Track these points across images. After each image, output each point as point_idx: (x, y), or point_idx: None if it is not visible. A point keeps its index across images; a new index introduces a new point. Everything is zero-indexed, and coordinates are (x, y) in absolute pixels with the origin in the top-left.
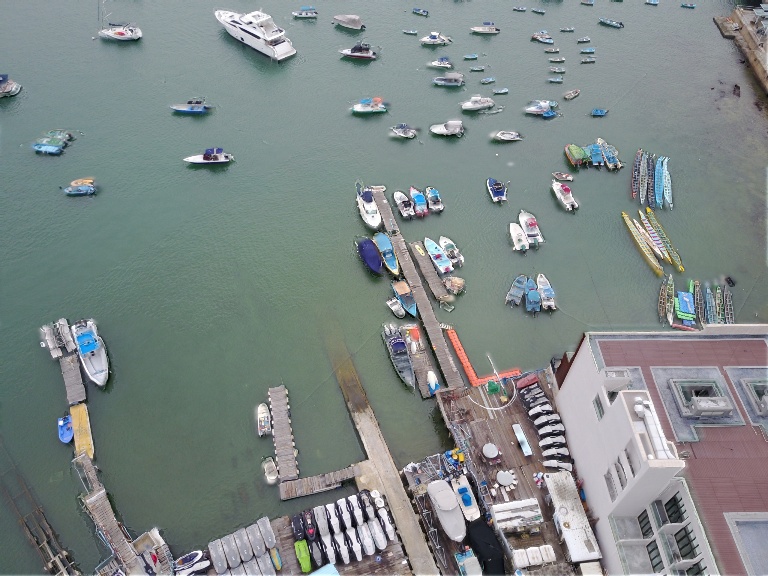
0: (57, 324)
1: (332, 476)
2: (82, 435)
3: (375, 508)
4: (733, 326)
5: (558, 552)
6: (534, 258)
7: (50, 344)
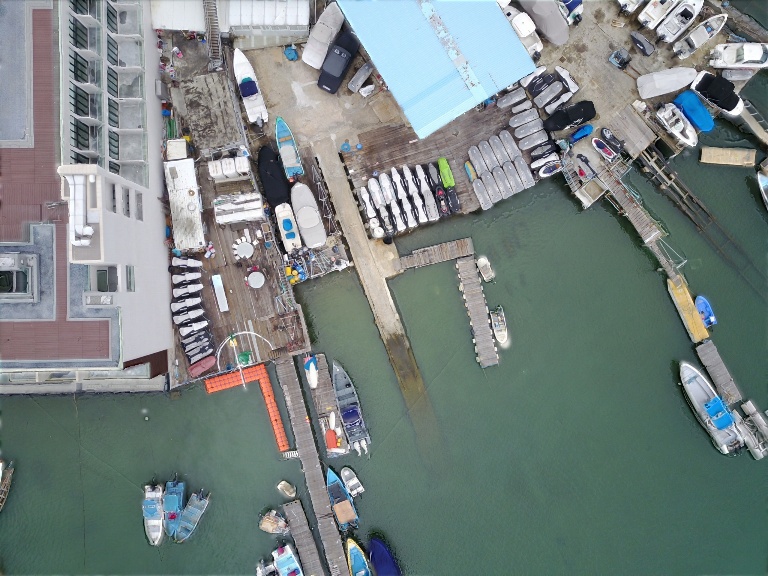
0: (763, 449)
1: (422, 260)
2: (686, 304)
3: (379, 217)
4: None
5: (204, 180)
6: None
7: (760, 419)
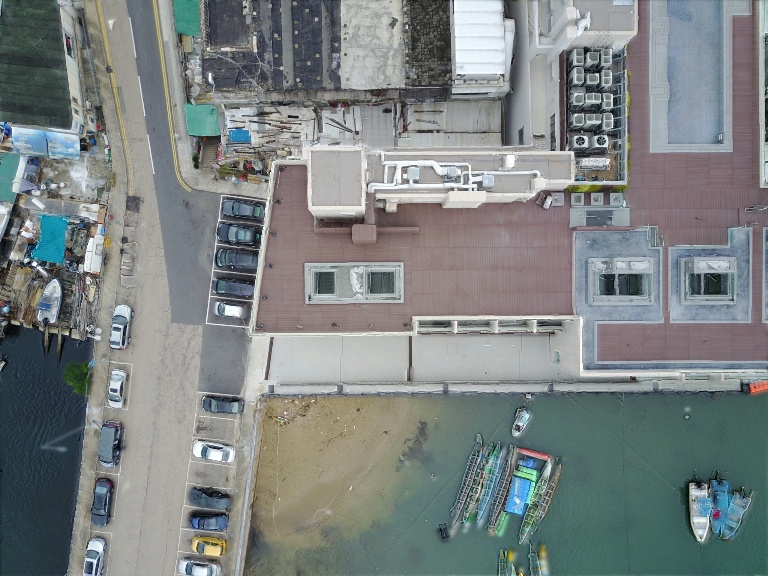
0: None
1: None
2: None
3: None
4: (647, 373)
5: None
6: (695, 575)
7: None
